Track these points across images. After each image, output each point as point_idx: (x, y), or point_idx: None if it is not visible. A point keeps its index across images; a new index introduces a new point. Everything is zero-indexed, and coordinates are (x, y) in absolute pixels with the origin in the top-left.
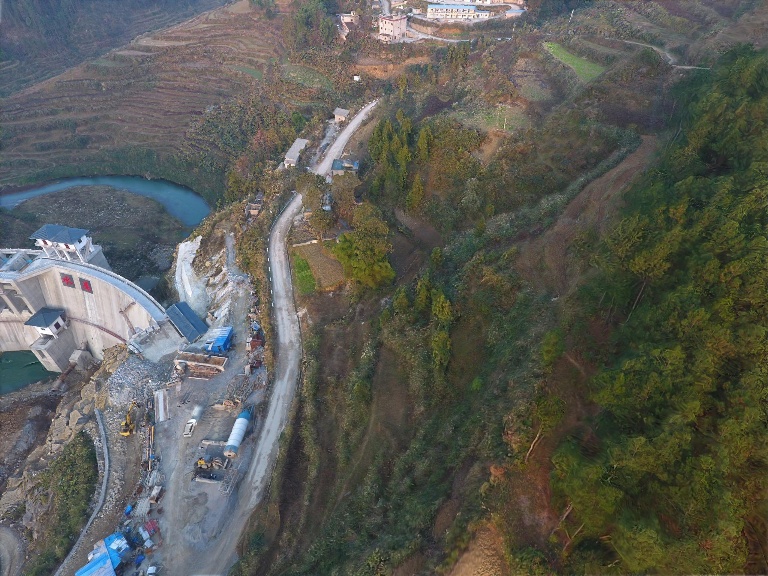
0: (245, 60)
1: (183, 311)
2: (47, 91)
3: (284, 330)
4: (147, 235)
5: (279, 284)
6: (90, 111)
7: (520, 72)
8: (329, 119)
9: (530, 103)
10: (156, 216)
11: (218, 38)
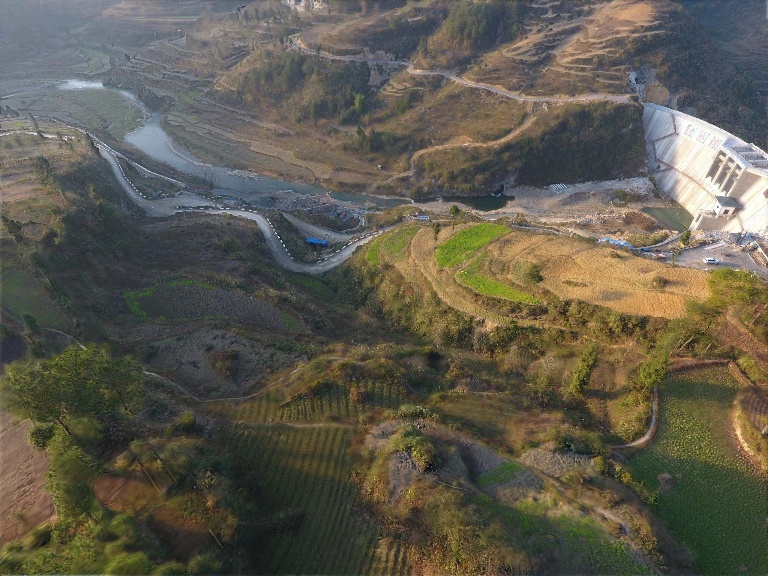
0: None
1: None
2: None
3: None
4: None
5: None
6: None
7: None
8: None
9: None
10: None
11: None
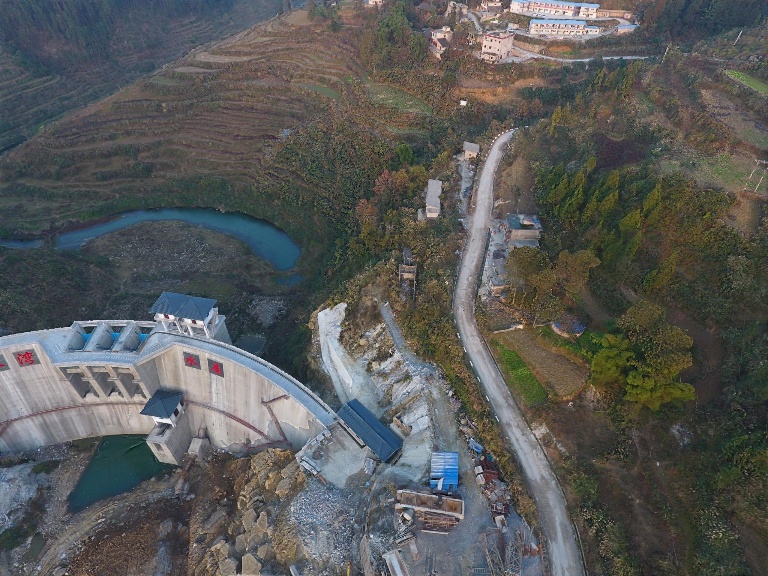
0: (315, 77)
1: (361, 414)
2: (104, 113)
3: (527, 459)
4: (240, 283)
5: (491, 386)
6: (152, 135)
7: (717, 109)
8: (456, 154)
9: (764, 152)
10: (243, 259)
11: (281, 53)
